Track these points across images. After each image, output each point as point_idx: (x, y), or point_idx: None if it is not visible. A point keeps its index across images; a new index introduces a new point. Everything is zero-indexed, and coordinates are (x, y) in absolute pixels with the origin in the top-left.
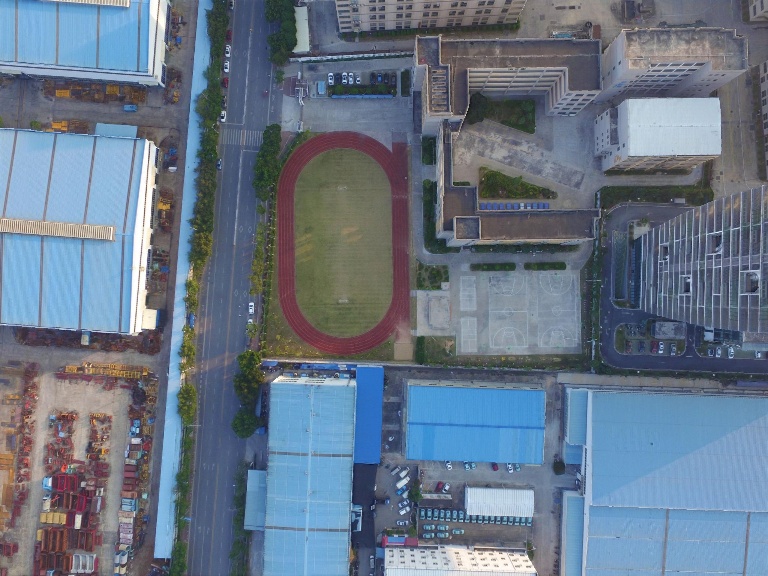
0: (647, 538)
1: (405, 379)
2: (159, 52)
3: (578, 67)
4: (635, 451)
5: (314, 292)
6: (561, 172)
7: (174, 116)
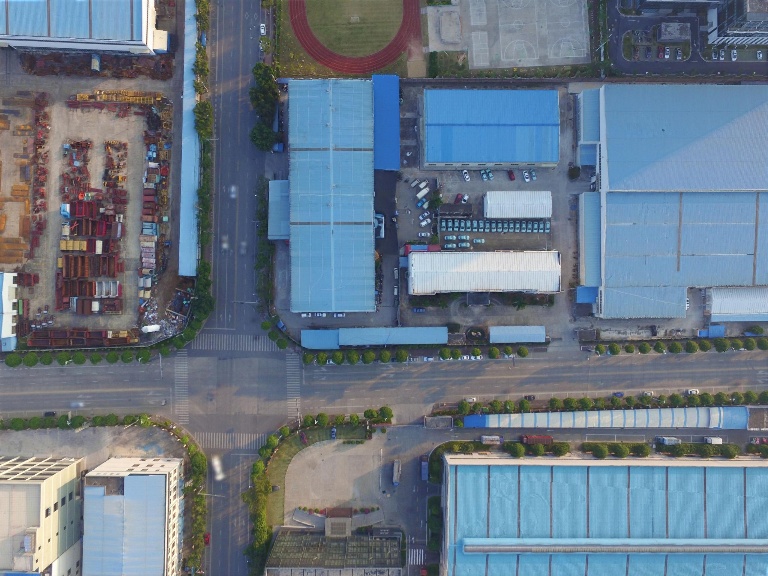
0: (662, 223)
1: (420, 95)
2: None
3: None
4: (648, 137)
5: (325, 13)
6: None
7: None
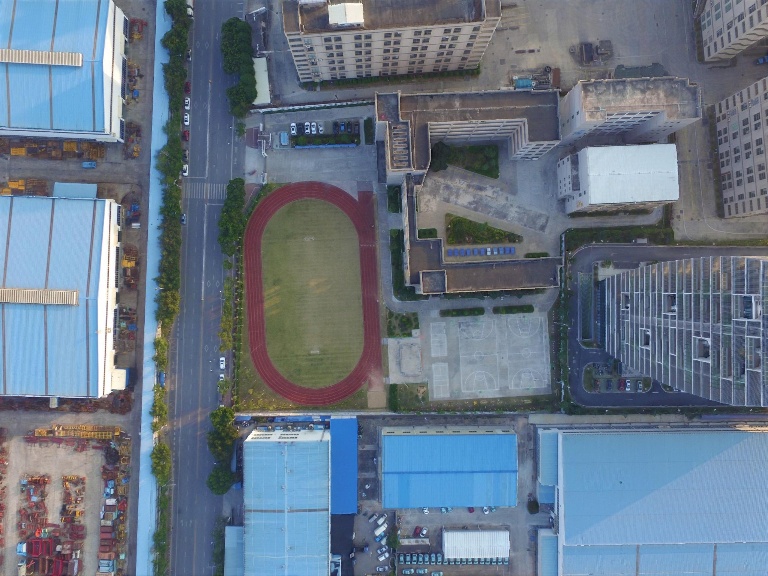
0: (619, 573)
1: (379, 427)
2: (116, 108)
3: (537, 118)
4: (605, 490)
5: (285, 344)
6: (526, 216)
7: (135, 171)
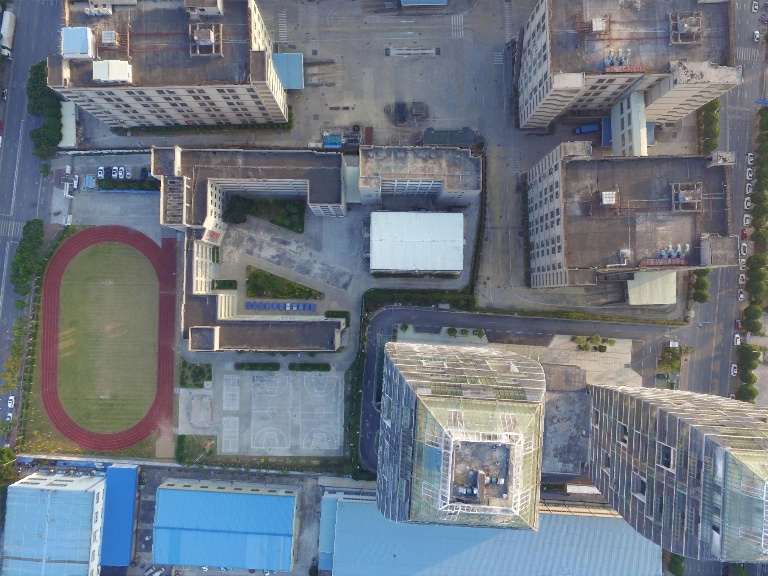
0: None
1: (164, 478)
2: None
3: (320, 179)
4: (377, 563)
5: (77, 387)
6: (329, 273)
7: None
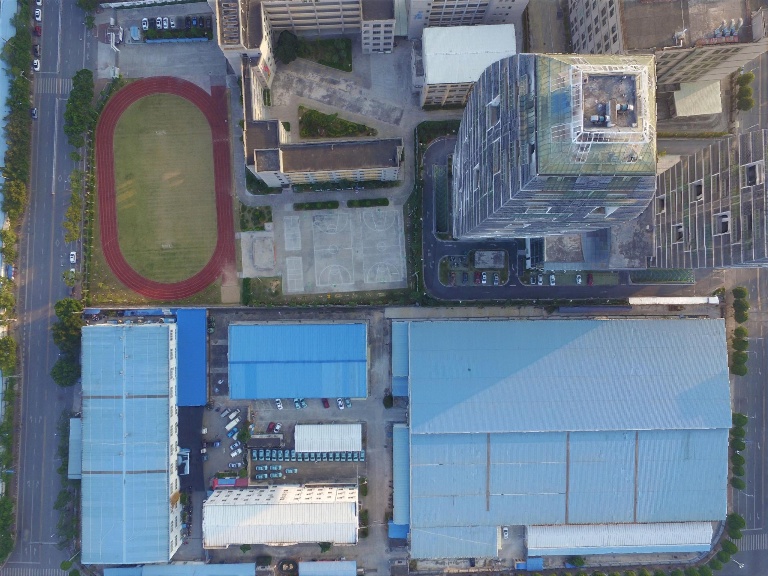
0: (470, 463)
1: (232, 321)
2: None
3: None
4: (453, 378)
5: (137, 239)
6: (380, 109)
7: None
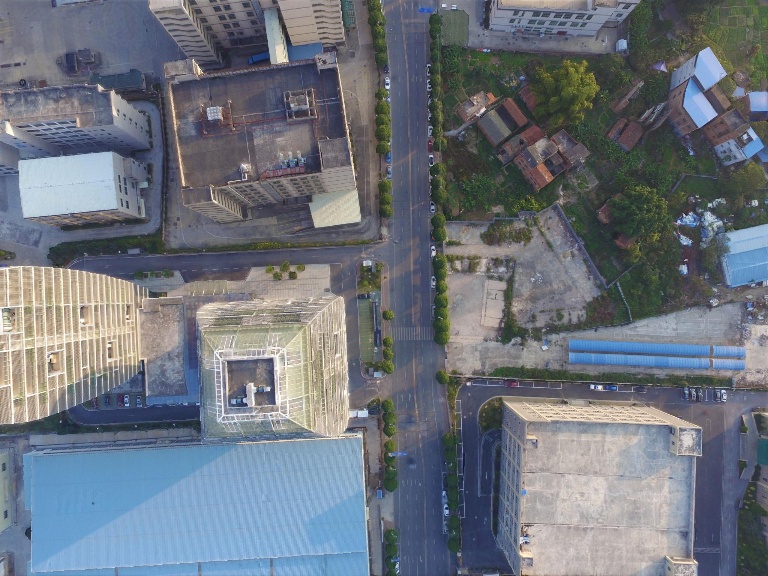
0: None
1: None
2: None
3: None
4: (76, 512)
5: None
6: (18, 232)
7: None
